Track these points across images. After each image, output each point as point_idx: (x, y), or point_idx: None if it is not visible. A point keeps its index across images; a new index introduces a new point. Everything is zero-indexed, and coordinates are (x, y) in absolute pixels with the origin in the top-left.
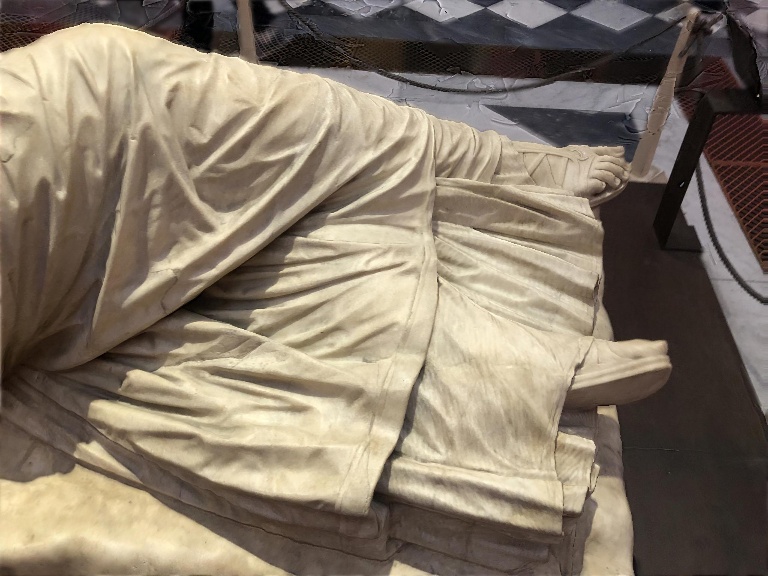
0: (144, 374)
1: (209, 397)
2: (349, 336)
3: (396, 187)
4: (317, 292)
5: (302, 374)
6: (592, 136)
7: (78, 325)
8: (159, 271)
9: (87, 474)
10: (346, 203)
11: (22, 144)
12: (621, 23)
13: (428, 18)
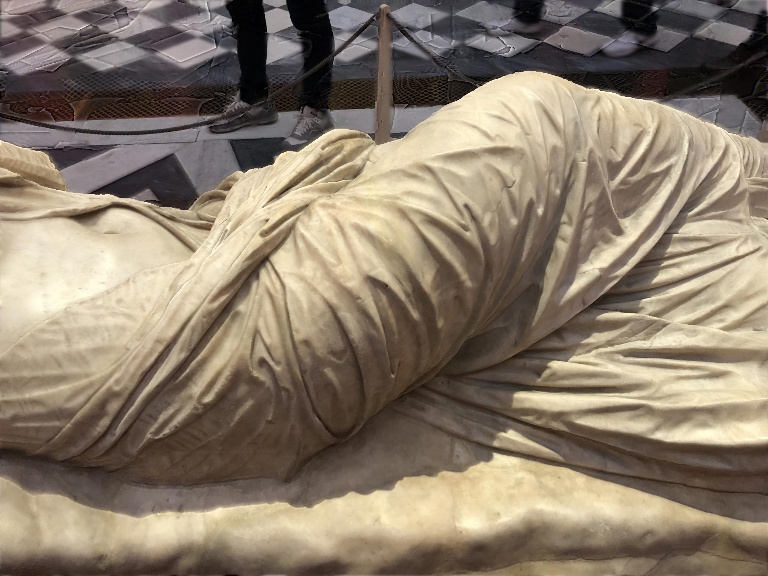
0: (565, 363)
1: (636, 374)
2: (737, 311)
3: (734, 186)
4: (698, 278)
5: (719, 344)
6: None
7: (498, 328)
8: (586, 272)
9: (508, 460)
10: (695, 204)
11: (518, 172)
12: (666, 45)
13: (496, 55)
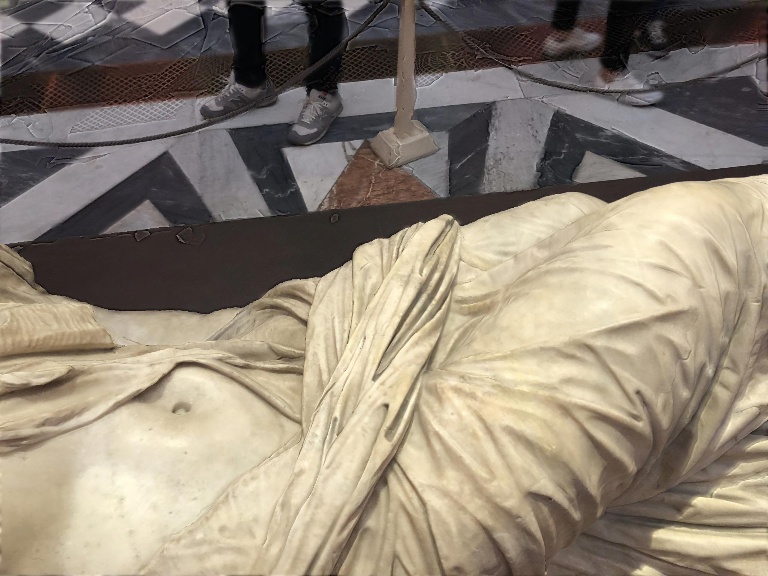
0: (712, 501)
1: None
2: None
3: None
4: None
5: None
6: (728, 105)
7: None
8: (743, 410)
9: None
10: None
11: (692, 337)
12: None
13: None
